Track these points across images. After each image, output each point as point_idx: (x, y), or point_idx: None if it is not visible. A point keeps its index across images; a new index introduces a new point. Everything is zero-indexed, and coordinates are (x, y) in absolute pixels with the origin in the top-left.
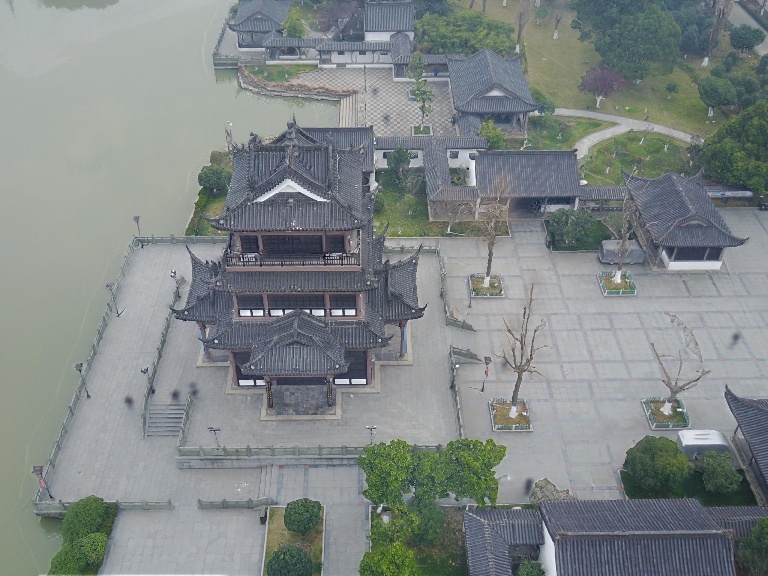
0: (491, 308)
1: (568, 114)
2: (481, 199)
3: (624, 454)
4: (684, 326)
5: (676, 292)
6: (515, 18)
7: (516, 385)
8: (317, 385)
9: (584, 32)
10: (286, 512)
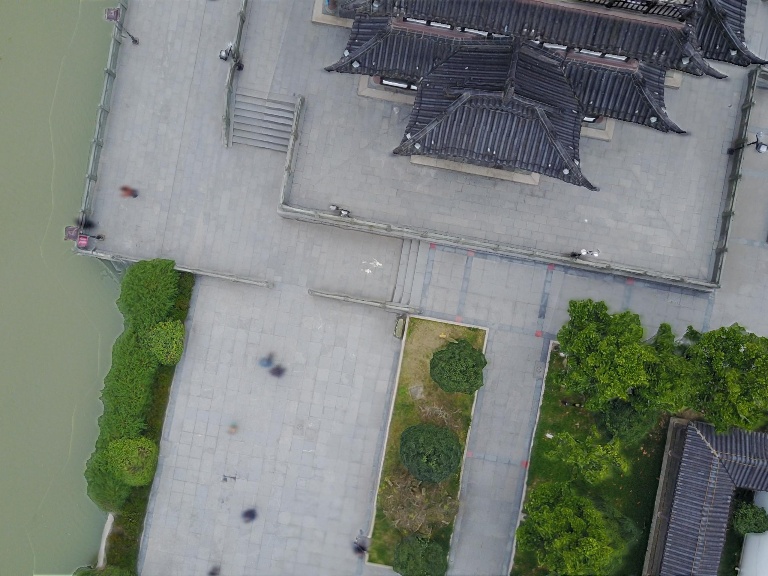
0: None
1: None
2: None
3: None
4: None
5: None
6: None
7: None
8: None
9: None
10: (436, 369)
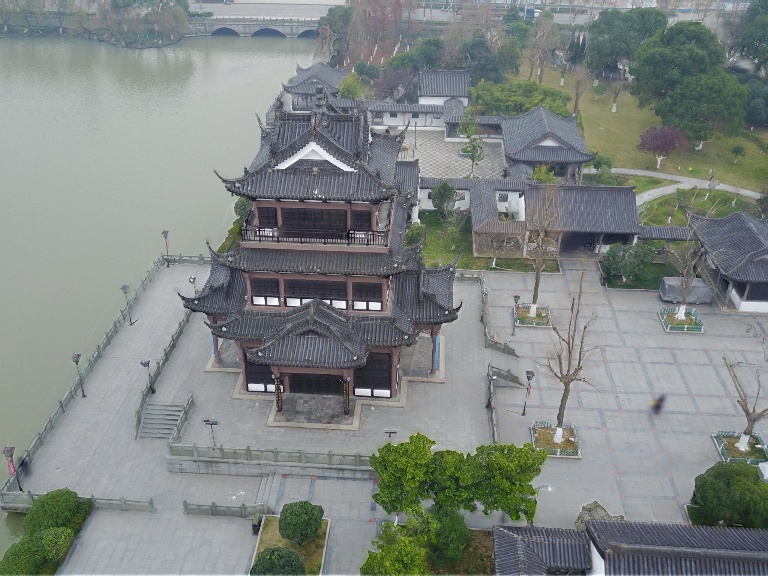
0: (537, 337)
1: (626, 173)
2: (530, 233)
3: (691, 489)
4: (762, 337)
5: None
6: (572, 87)
7: (562, 400)
8: (335, 395)
9: (644, 97)
10: (281, 514)
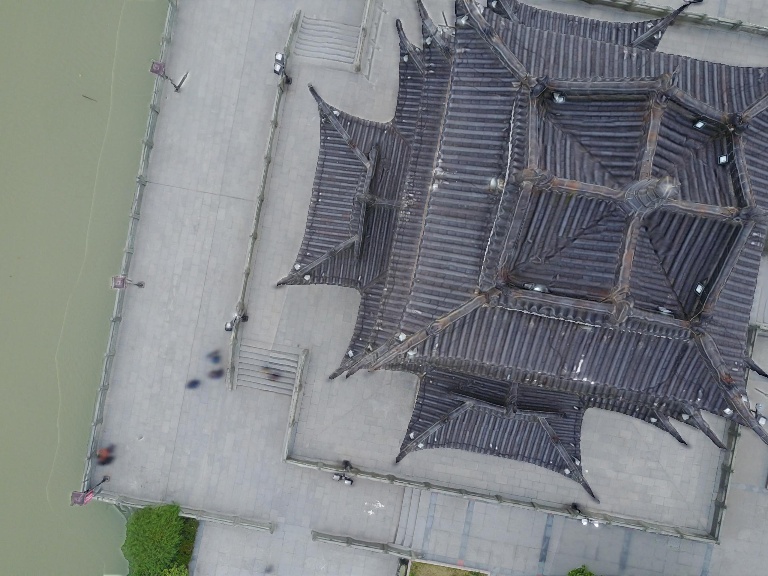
0: None
1: None
2: None
3: None
4: None
5: None
6: None
7: None
8: None
9: None
10: None
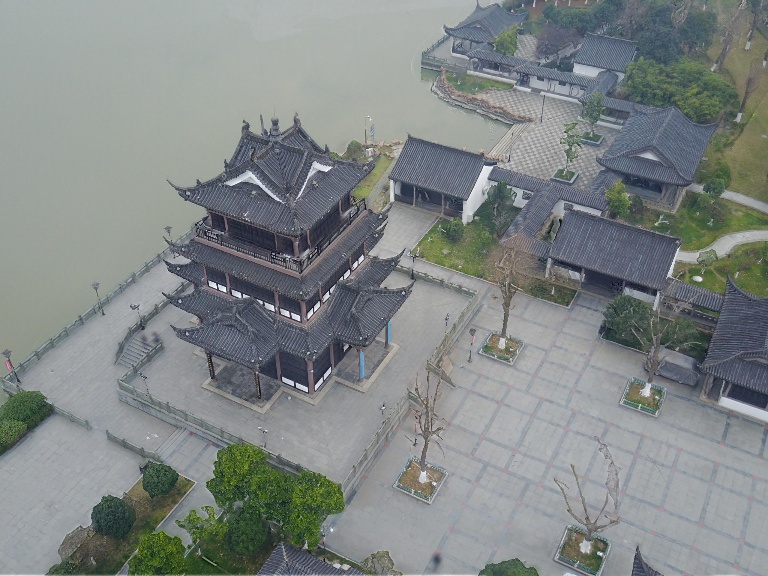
0: (490, 370)
1: (742, 202)
2: (552, 259)
3: None
4: (611, 460)
5: (708, 431)
6: None
7: (423, 449)
8: (268, 376)
9: None
10: (145, 470)
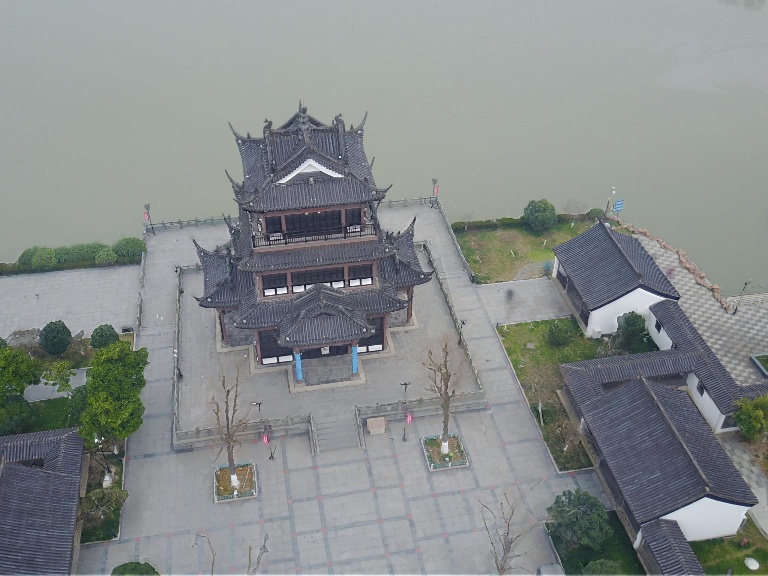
0: (408, 459)
1: None
2: None
3: None
4: None
5: None
6: None
7: None
8: None
9: None
10: None
